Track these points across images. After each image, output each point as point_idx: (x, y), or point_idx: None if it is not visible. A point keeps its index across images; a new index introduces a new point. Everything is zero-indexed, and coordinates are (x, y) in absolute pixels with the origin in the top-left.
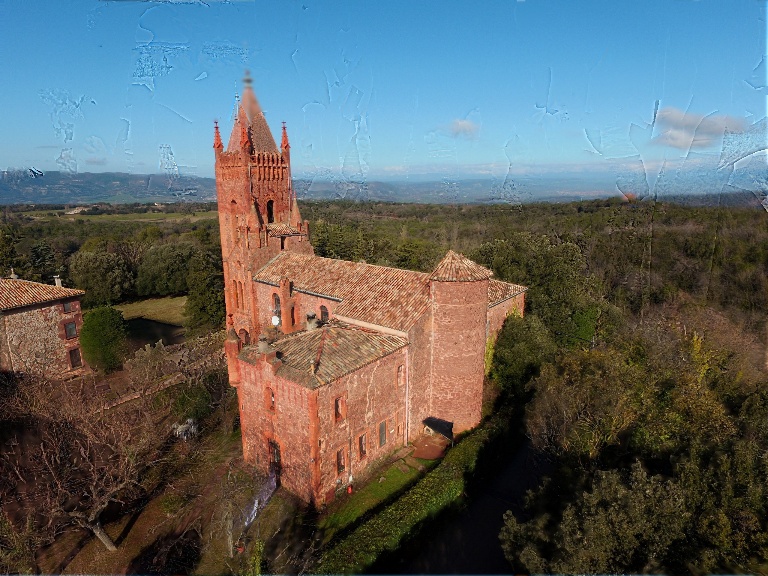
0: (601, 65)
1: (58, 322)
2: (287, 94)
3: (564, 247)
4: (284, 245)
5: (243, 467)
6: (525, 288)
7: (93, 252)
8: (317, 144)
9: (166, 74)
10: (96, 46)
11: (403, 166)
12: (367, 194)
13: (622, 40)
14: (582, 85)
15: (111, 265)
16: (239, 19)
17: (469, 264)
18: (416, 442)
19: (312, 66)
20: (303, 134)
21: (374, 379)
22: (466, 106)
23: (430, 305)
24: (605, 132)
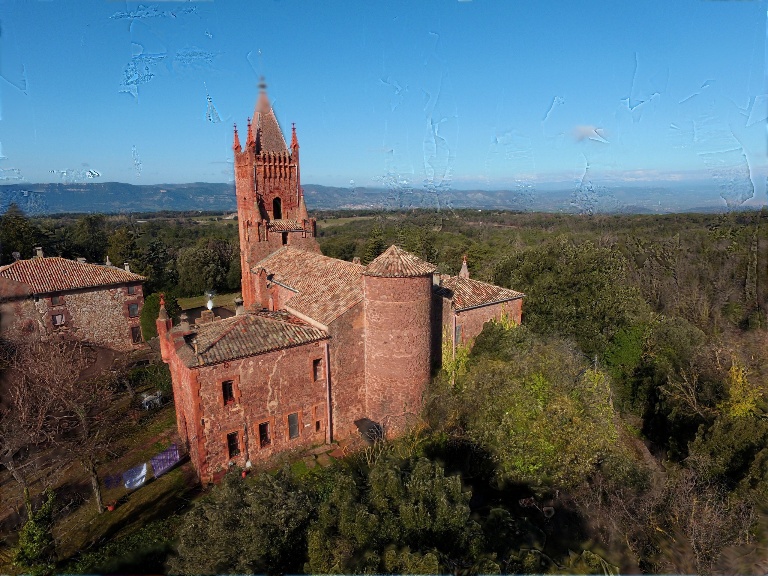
0: (685, 44)
1: (123, 302)
2: (255, 93)
3: (596, 253)
4: (287, 240)
5: (174, 439)
6: (521, 294)
7: (196, 248)
8: (404, 150)
9: (148, 81)
10: (89, 61)
11: (484, 170)
12: (431, 197)
13: (713, 12)
14: (662, 69)
15: (207, 260)
16: (201, 26)
17: (406, 260)
18: (343, 441)
19: (263, 64)
20: (384, 140)
21: (278, 368)
22: (549, 103)
23: (361, 300)
24: (699, 123)
